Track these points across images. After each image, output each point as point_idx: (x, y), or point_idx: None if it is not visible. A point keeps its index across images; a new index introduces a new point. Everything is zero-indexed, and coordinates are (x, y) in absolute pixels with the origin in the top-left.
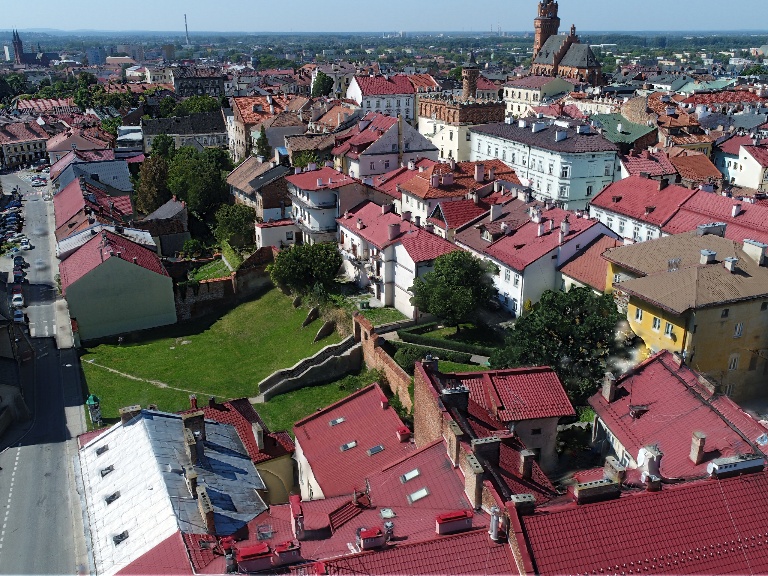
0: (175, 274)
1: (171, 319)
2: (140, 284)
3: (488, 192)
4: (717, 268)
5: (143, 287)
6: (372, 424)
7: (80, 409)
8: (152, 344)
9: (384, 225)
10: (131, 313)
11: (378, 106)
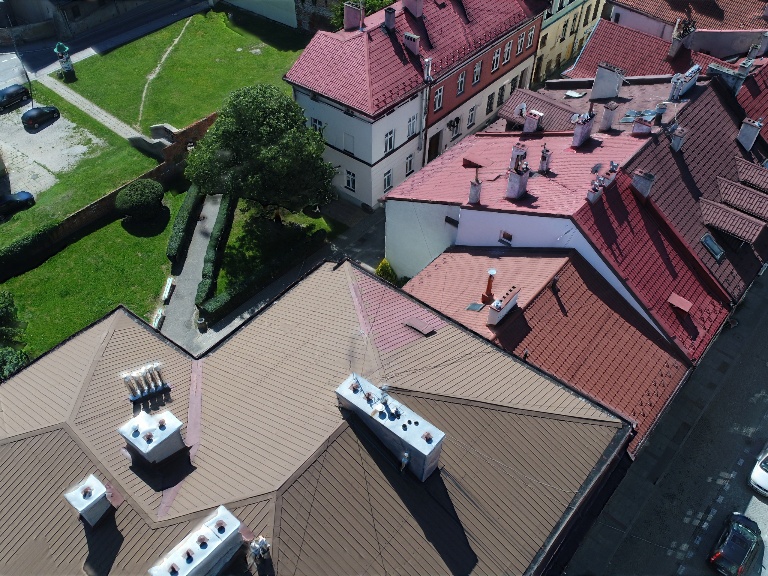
0: None
1: (292, 20)
2: None
3: (749, 48)
4: (89, 473)
5: None
6: None
7: (89, 55)
8: (241, 36)
9: (401, 4)
10: None
11: None
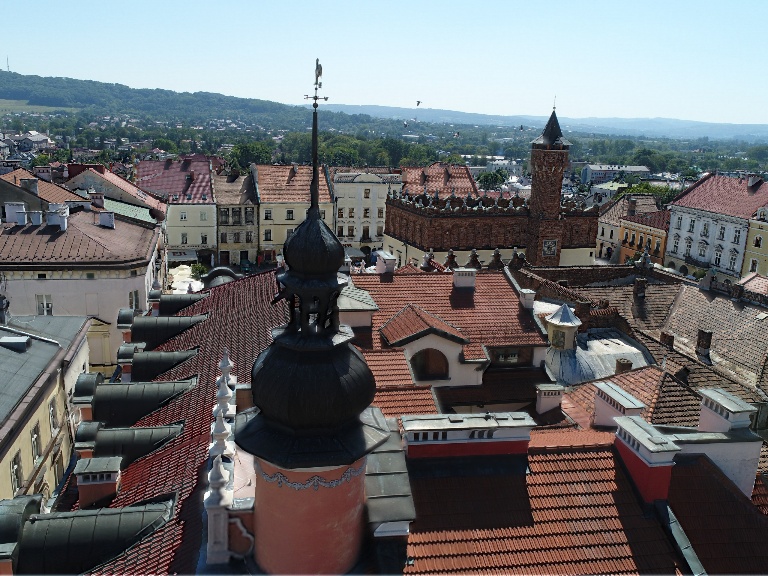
0: None
1: None
2: None
3: None
4: None
5: None
6: None
7: None
8: None
9: None
10: None
11: (692, 230)
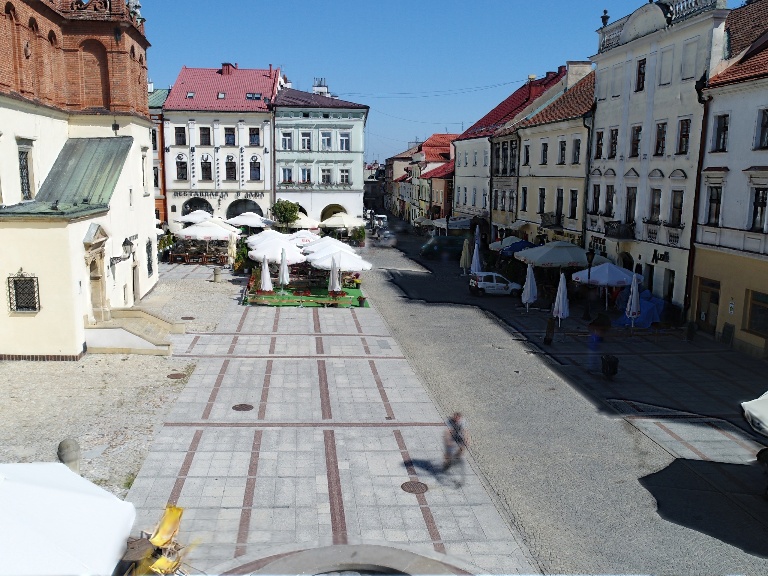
0: None
1: None
2: None
3: None
4: None
5: None
6: None
7: None
8: None
9: None
10: None
11: None
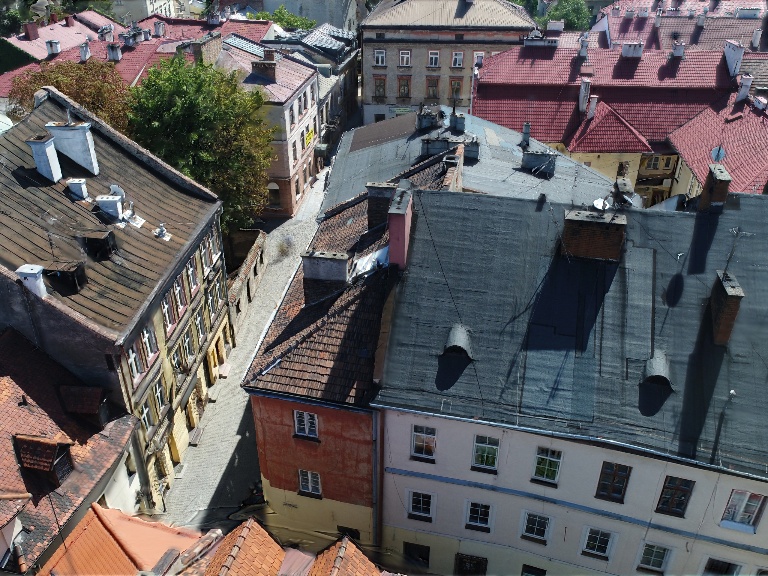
0: None
1: None
2: None
3: None
4: None
5: None
6: None
7: None
8: None
9: None
10: None
11: None
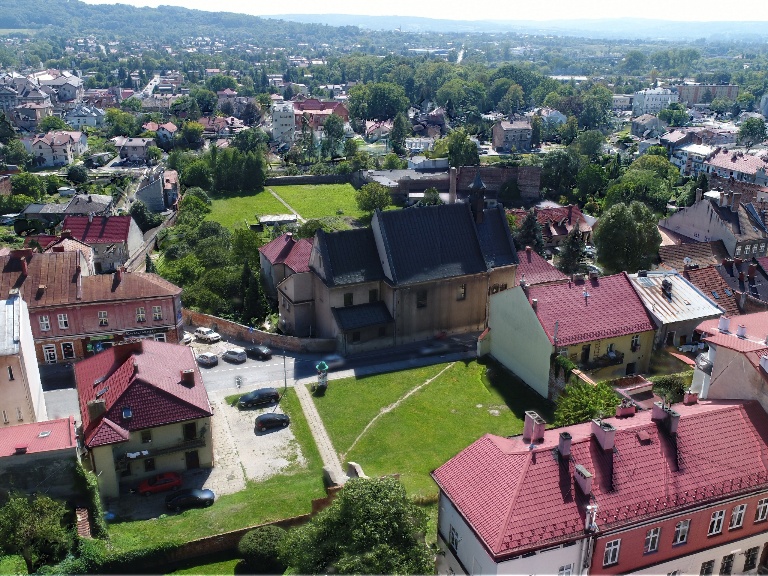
0: (669, 368)
1: (544, 390)
2: (531, 331)
3: None
4: None
5: (532, 336)
6: (5, 449)
7: (348, 376)
8: (489, 392)
9: None
10: (520, 356)
11: None
